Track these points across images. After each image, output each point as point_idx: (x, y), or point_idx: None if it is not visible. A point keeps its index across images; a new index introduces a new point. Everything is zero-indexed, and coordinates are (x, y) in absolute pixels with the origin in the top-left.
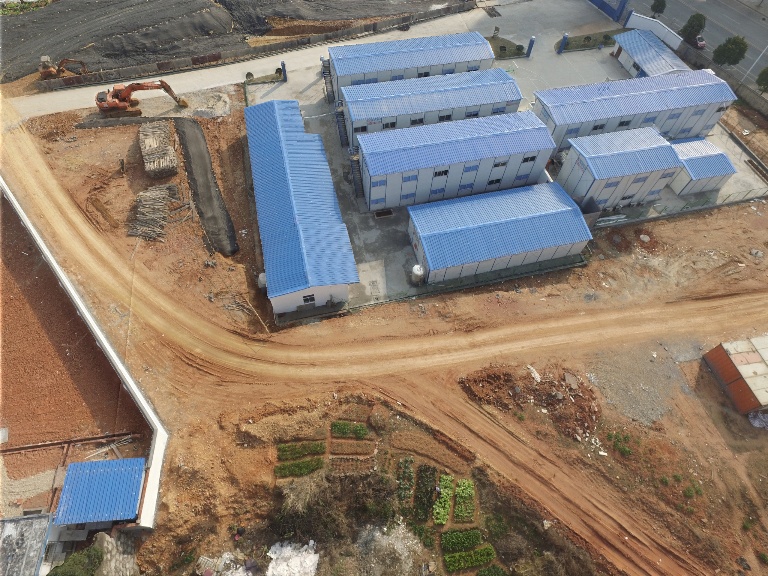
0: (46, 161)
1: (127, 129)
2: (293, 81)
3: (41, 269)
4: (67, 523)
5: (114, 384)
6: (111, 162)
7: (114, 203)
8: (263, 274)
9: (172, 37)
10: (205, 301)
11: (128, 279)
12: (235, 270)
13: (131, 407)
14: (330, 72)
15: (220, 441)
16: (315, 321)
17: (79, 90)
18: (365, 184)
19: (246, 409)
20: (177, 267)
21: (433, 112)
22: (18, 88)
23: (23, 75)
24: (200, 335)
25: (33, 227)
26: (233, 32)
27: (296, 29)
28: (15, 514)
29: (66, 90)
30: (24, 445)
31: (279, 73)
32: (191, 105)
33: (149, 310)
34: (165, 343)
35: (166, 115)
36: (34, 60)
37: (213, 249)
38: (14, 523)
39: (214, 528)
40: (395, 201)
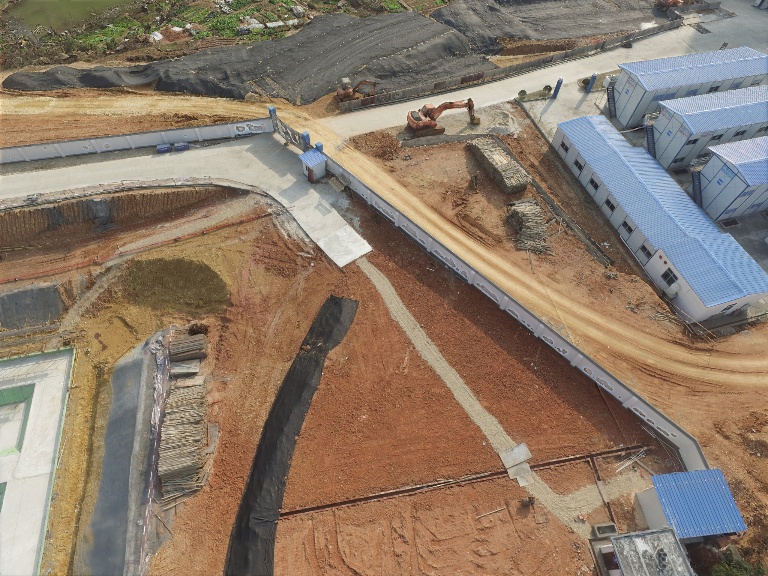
0: (395, 179)
1: (452, 146)
2: (562, 98)
3: (457, 284)
4: (687, 537)
5: (597, 397)
6: (457, 179)
7: (484, 218)
8: (677, 284)
9: (429, 58)
10: (629, 312)
11: (543, 292)
12: (638, 281)
13: (627, 419)
14: (614, 88)
15: (735, 451)
16: (732, 330)
17: (374, 110)
18: (716, 195)
19: (735, 418)
20: (581, 279)
21: (760, 124)
22: (320, 109)
23: (318, 97)
24: (644, 346)
25: (423, 243)
26: (471, 52)
27: (525, 48)
28: (586, 530)
29: (363, 110)
30: (549, 460)
31: (548, 90)
32: (481, 122)
33: (581, 322)
34: (615, 355)
35: (465, 133)
36: (319, 82)
37: (606, 261)
38: (641, 538)
39: (767, 539)
40: (741, 211)
